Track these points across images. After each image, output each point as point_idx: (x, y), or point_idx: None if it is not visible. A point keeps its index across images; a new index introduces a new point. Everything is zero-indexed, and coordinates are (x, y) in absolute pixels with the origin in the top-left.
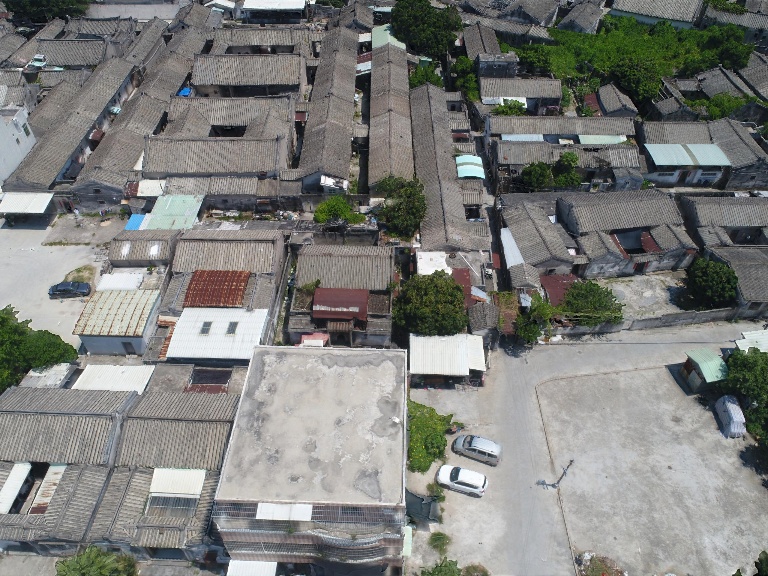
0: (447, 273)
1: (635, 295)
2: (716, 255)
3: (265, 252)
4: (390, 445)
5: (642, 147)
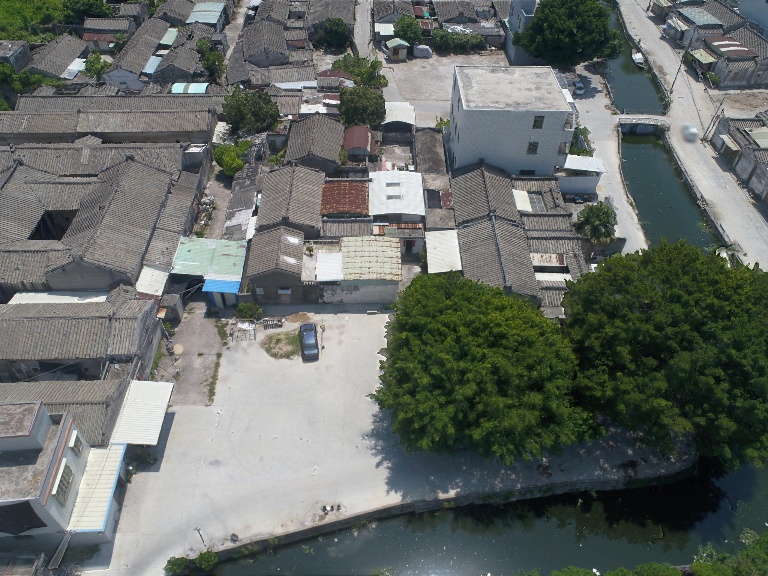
0: None
1: (330, 65)
2: (318, 23)
3: (304, 173)
4: (519, 70)
5: None
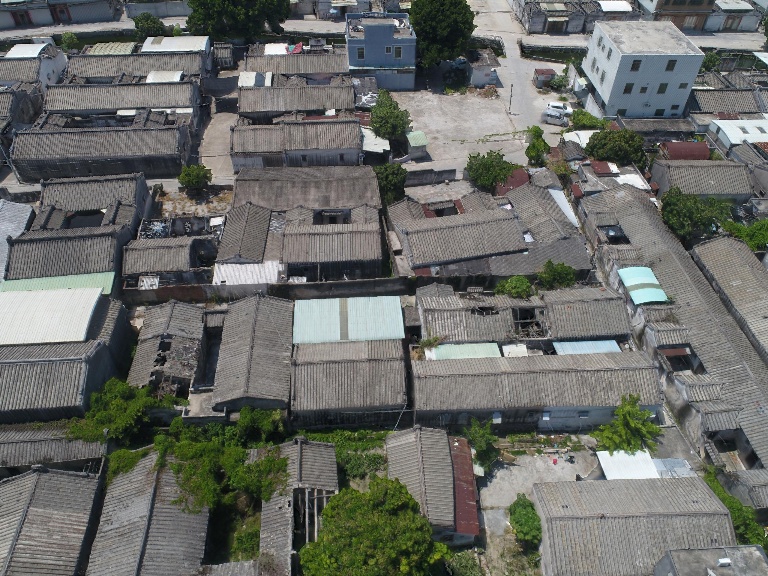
0: (616, 144)
1: None
2: None
3: None
4: (610, 33)
5: (403, 348)
